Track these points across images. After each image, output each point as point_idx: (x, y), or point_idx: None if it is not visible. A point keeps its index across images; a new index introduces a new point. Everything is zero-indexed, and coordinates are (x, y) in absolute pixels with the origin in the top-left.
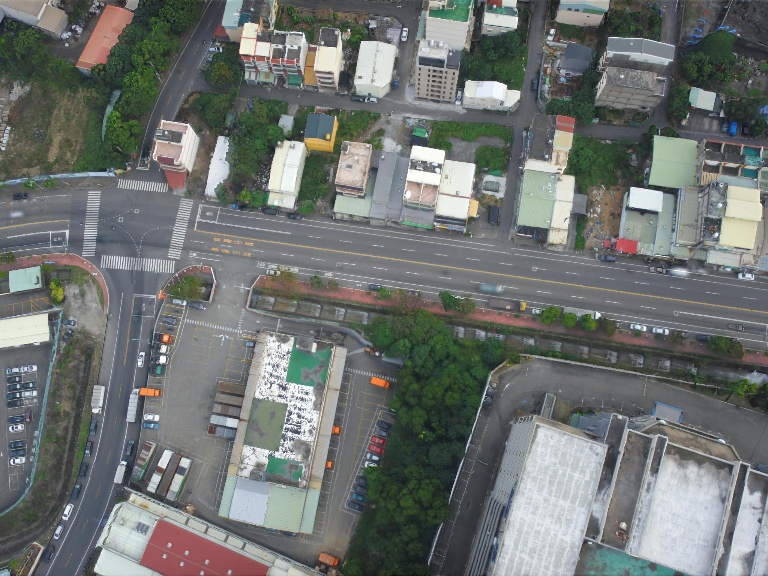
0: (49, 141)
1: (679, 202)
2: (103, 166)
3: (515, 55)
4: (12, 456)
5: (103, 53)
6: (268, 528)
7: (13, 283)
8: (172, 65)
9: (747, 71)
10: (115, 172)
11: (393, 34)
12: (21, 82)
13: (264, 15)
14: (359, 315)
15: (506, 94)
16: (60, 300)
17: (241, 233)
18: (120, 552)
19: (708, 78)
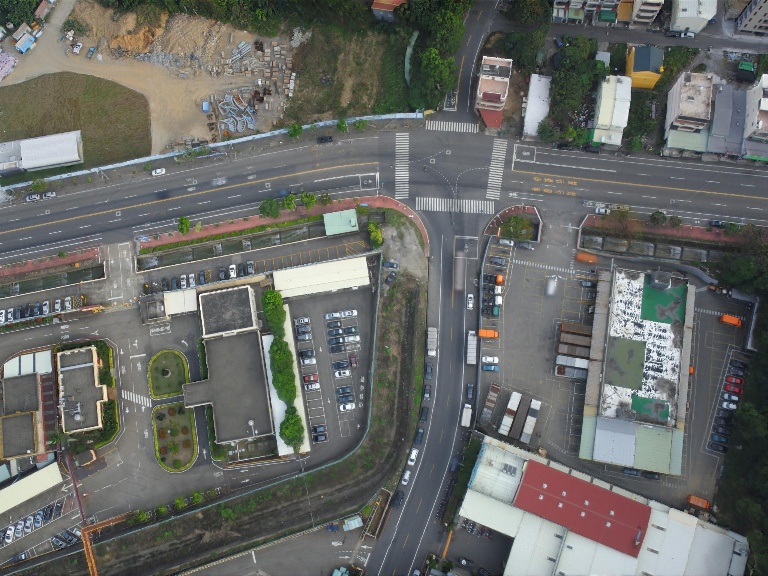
0: (341, 86)
1: None
2: (418, 105)
3: None
4: (341, 402)
5: None
6: (627, 471)
7: (329, 226)
8: None
9: None
10: (423, 113)
11: None
12: (302, 28)
13: None
14: (697, 253)
15: None
16: (380, 242)
17: (562, 172)
18: None
19: None
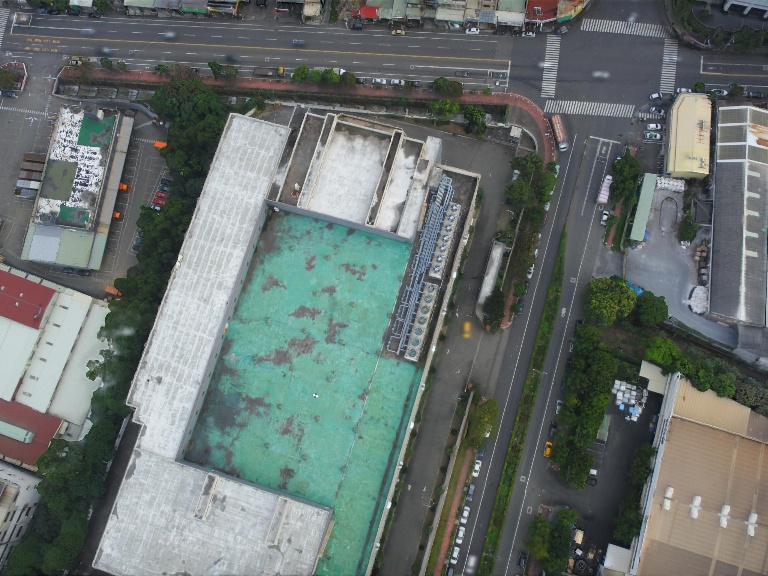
0: None
1: None
2: None
3: None
4: None
5: None
6: (66, 271)
7: None
8: None
9: None
10: None
11: None
12: None
13: None
14: (149, 94)
15: None
16: None
17: (50, 33)
18: None
19: None
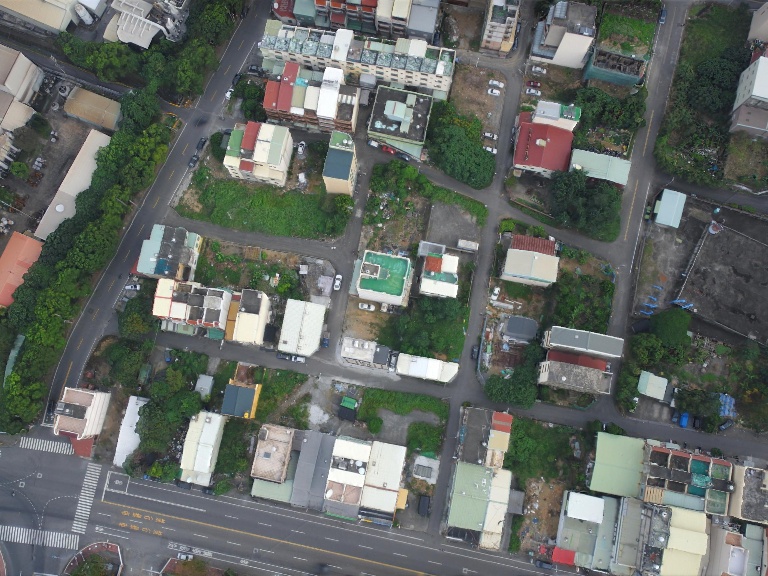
0: None
1: (621, 514)
2: (1, 431)
3: (455, 318)
4: None
5: (7, 291)
6: None
7: None
8: (84, 303)
9: (702, 355)
10: None
11: (325, 283)
12: None
13: (183, 261)
14: None
15: (442, 368)
16: None
17: (152, 507)
18: None
19: (660, 359)
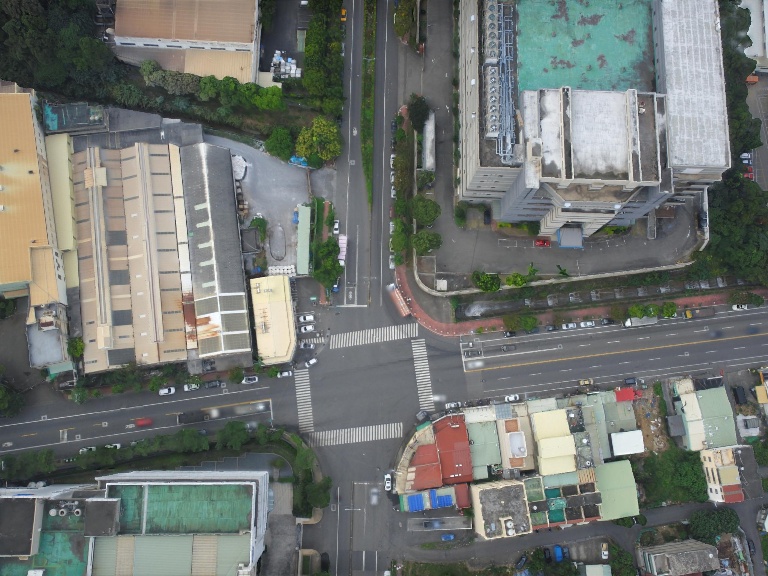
0: None
1: None
2: None
3: None
4: None
5: None
6: None
7: None
8: None
9: None
10: None
11: None
12: None
13: None
14: None
15: None
16: None
17: None
18: None
19: None
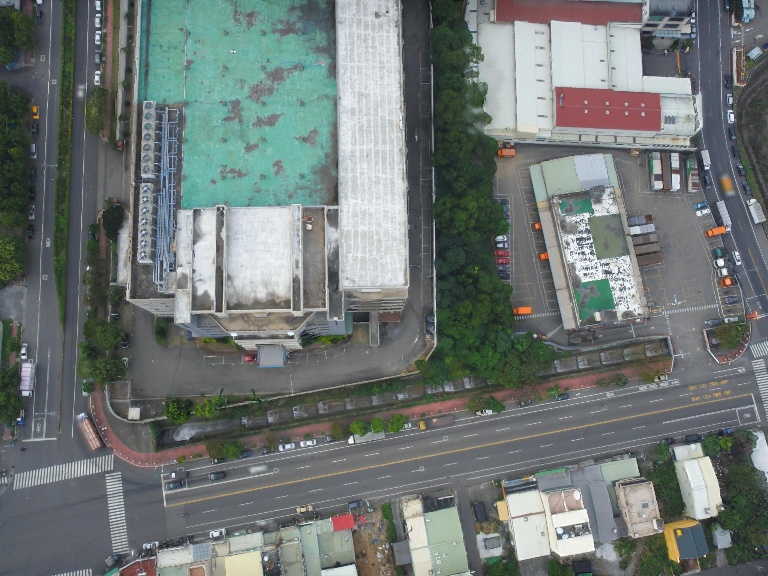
0: None
1: None
2: None
3: None
4: None
5: None
6: None
7: None
8: None
9: None
10: None
11: None
12: None
13: None
14: (565, 367)
15: None
16: None
17: (708, 407)
18: (677, 98)
19: None
